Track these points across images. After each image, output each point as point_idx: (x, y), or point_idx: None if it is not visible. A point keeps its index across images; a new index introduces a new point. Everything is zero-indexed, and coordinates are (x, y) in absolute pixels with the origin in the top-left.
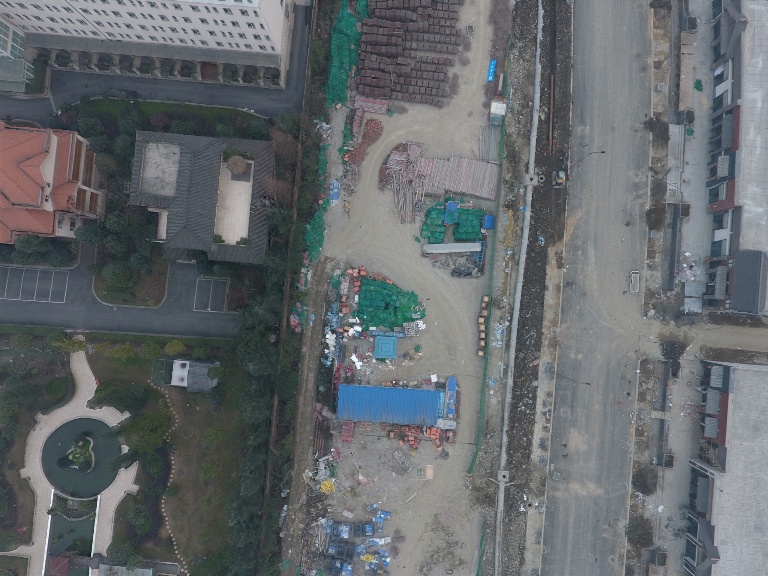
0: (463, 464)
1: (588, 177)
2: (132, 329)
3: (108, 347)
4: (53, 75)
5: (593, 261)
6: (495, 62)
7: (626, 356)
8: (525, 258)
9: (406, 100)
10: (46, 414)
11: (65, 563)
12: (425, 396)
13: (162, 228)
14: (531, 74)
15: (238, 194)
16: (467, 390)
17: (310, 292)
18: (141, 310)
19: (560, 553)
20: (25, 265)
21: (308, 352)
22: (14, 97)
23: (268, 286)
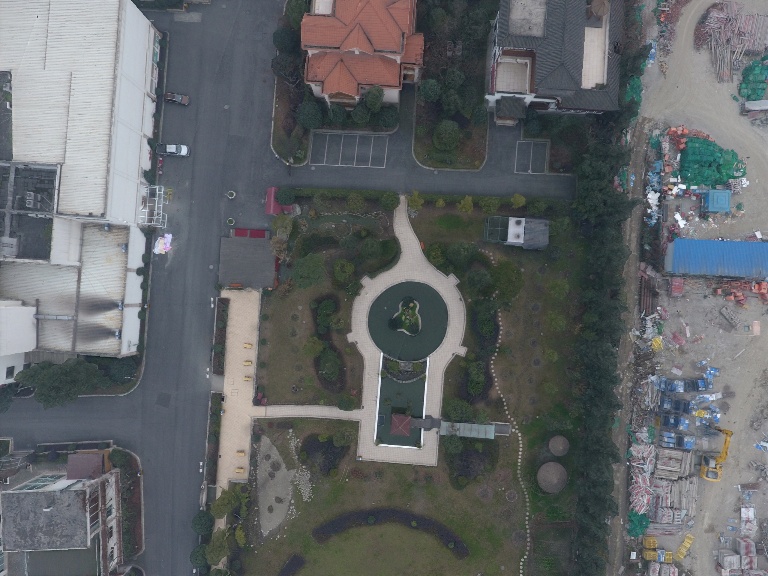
0: None
1: None
2: (453, 192)
3: (431, 210)
4: None
5: None
6: None
7: None
8: None
9: None
10: (374, 277)
11: (409, 420)
12: (761, 248)
13: (498, 83)
14: None
15: (591, 41)
16: None
17: None
18: (462, 173)
19: None
20: (344, 130)
21: None
22: None
23: (592, 145)
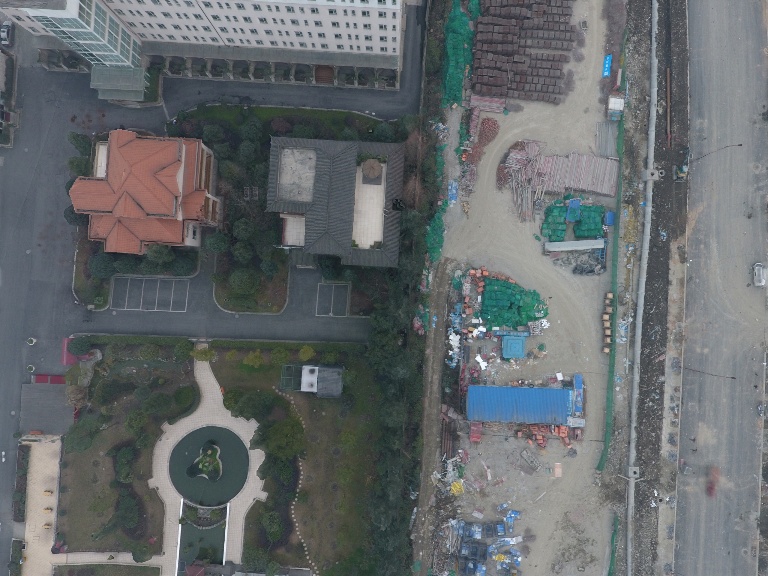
0: (591, 461)
1: (708, 170)
2: (255, 336)
3: None
4: (165, 83)
5: (716, 255)
6: (611, 57)
7: (752, 349)
8: (648, 253)
9: (522, 98)
10: (173, 423)
11: (202, 572)
12: (556, 395)
13: (288, 234)
14: (646, 68)
15: (370, 198)
16: (593, 387)
17: (432, 294)
18: (263, 317)
19: (693, 547)
20: (145, 275)
21: (432, 354)
22: (127, 106)
23: (391, 289)
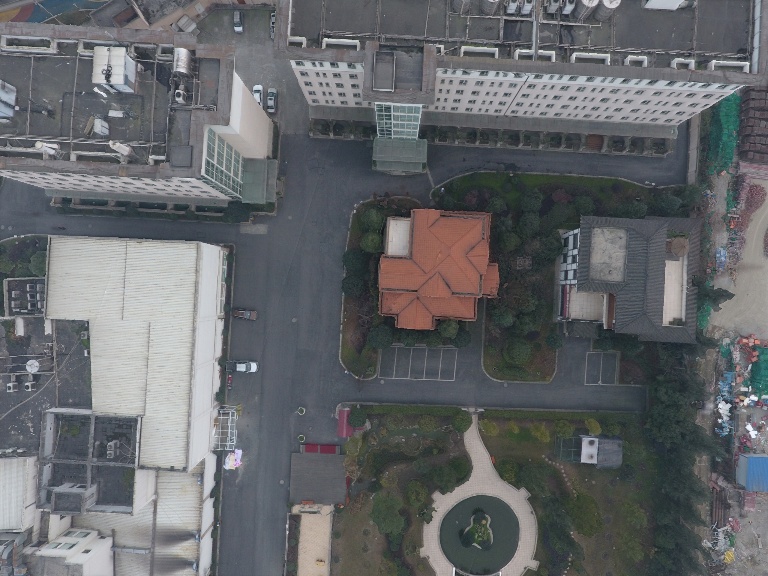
0: None
1: None
2: (523, 405)
3: (501, 424)
4: (429, 150)
5: None
6: None
7: None
8: None
9: None
10: (446, 493)
11: None
12: None
13: (571, 306)
14: None
15: (668, 274)
16: None
17: (700, 362)
18: (532, 385)
19: None
20: None
21: (700, 422)
22: (391, 173)
23: (663, 358)
